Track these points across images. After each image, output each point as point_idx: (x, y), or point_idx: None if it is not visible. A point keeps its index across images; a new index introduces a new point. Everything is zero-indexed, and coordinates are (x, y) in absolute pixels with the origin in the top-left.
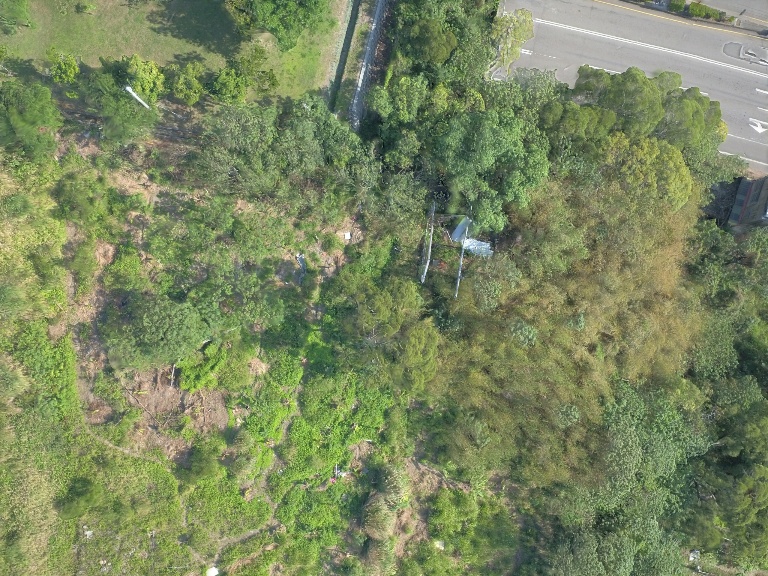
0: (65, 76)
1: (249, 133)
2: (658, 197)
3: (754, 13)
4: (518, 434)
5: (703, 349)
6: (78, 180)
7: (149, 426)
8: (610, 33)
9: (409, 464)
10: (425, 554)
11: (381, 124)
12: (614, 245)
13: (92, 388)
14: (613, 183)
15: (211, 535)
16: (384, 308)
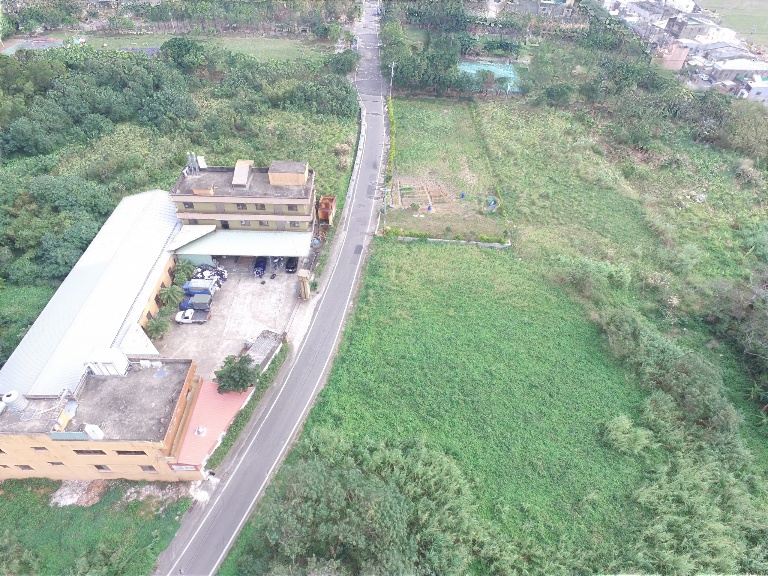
0: None
1: None
2: None
3: None
4: None
5: None
6: None
7: None
8: None
9: None
10: (764, 190)
11: None
12: None
13: (608, 155)
14: None
15: None
16: None
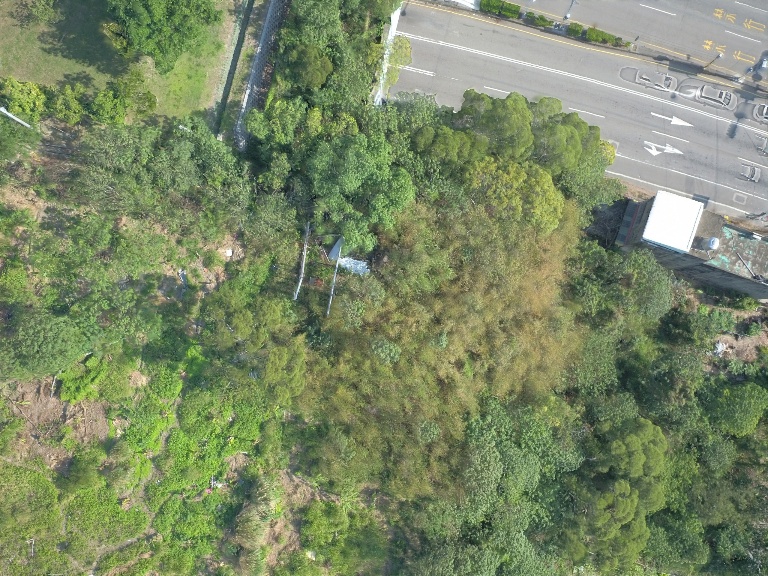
0: None
1: (124, 153)
2: (525, 220)
3: (650, 39)
4: (385, 448)
5: (581, 367)
6: None
7: (31, 436)
8: (510, 56)
9: (284, 476)
10: (296, 564)
11: (260, 145)
12: (481, 266)
13: None
14: (478, 206)
15: (90, 543)
16: (242, 326)
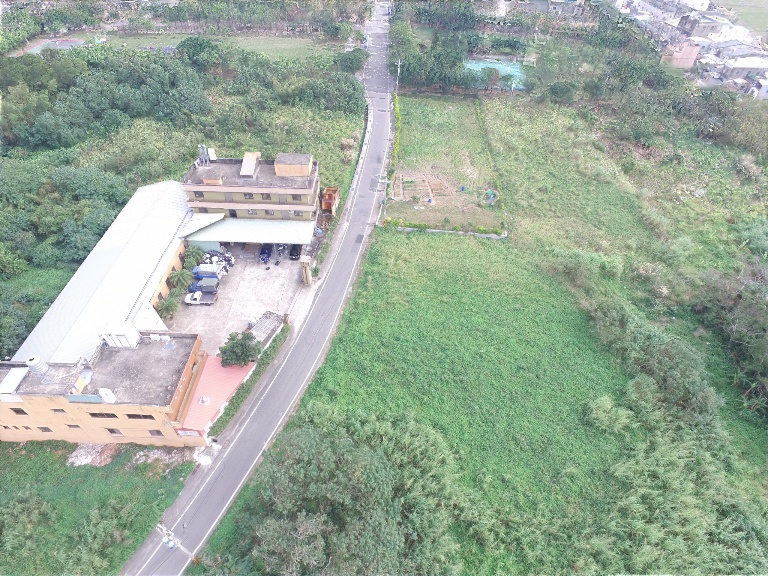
0: None
1: None
2: None
3: None
4: None
5: None
6: None
7: None
8: None
9: None
10: (765, 186)
11: None
12: (760, 124)
13: (609, 151)
14: None
15: None
16: None
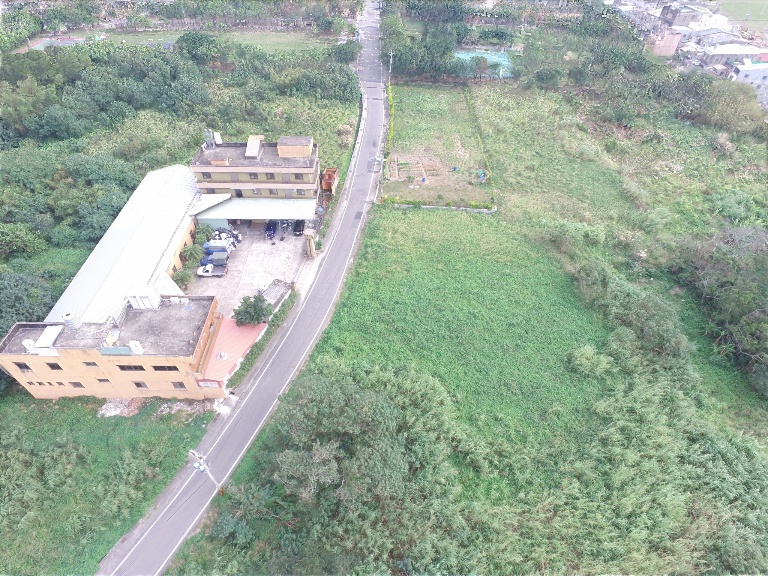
0: None
1: None
2: None
3: None
4: None
5: None
6: None
7: None
8: None
9: None
10: None
11: None
12: None
13: (593, 133)
14: None
15: None
16: None
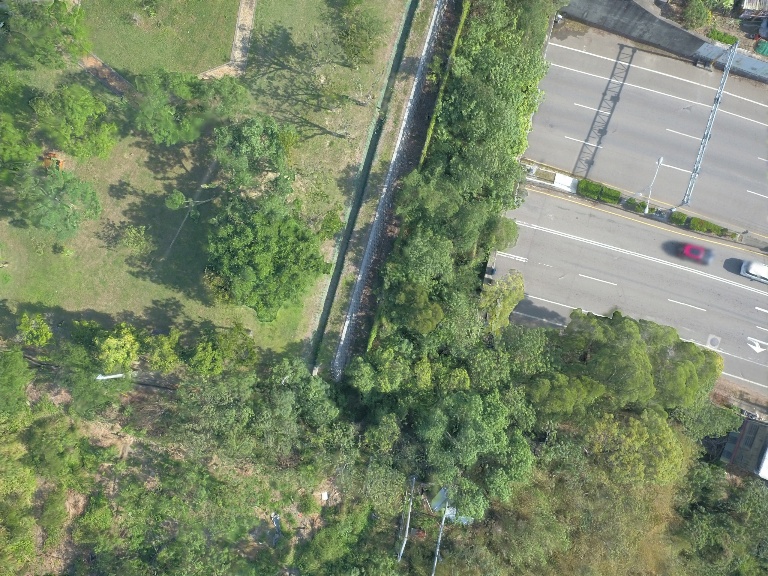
0: (36, 341)
1: (224, 412)
2: (645, 483)
3: (757, 228)
4: None
5: None
6: (49, 430)
7: None
8: (608, 243)
9: None
10: None
11: None
12: (598, 531)
13: None
14: (599, 474)
15: None
16: None
